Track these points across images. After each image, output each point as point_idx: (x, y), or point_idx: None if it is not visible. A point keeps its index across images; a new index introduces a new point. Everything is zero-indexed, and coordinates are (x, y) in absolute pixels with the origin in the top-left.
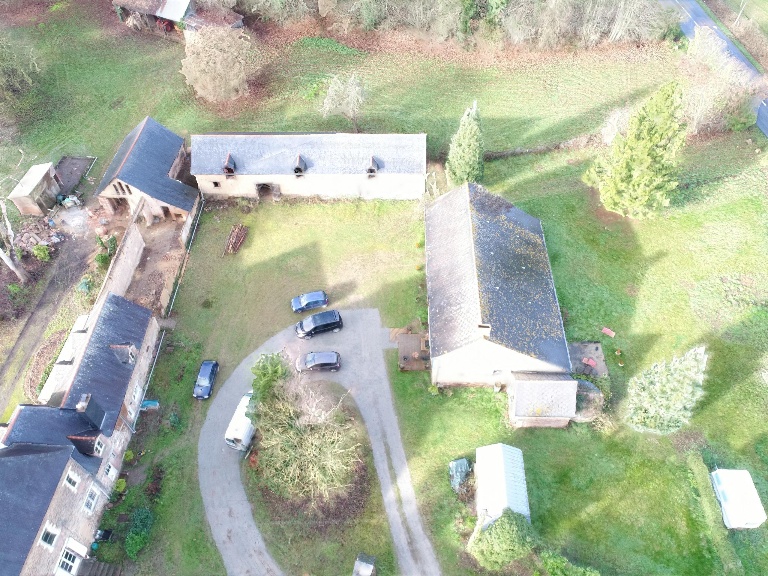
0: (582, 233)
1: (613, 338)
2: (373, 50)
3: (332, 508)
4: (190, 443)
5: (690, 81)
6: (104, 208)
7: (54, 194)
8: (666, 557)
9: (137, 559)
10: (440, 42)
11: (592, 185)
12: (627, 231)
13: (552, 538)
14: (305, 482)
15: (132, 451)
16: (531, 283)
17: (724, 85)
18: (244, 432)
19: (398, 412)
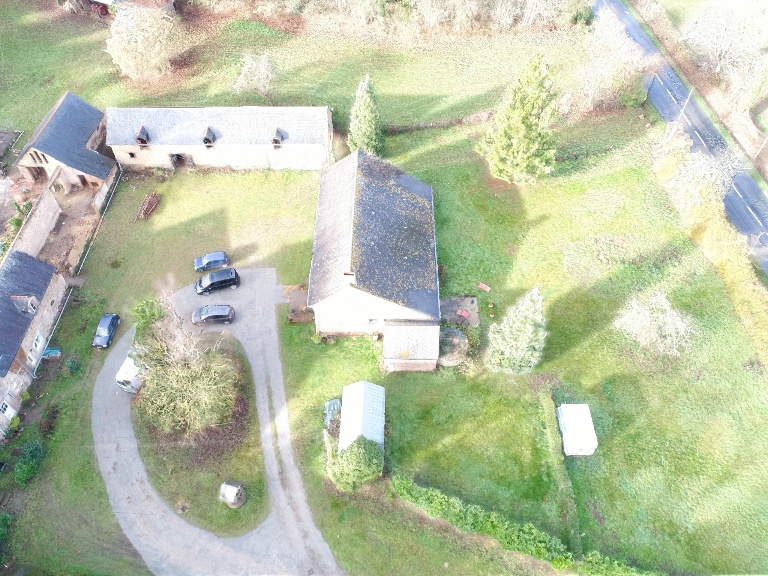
0: (473, 199)
1: (488, 292)
2: (298, 33)
3: (212, 443)
4: (86, 387)
5: (595, 62)
6: (25, 177)
7: None
8: (508, 481)
9: (26, 487)
10: (362, 25)
11: (484, 155)
12: (515, 197)
13: (408, 466)
14: (181, 415)
15: (31, 394)
16: (411, 241)
17: (620, 64)
18: (133, 375)
19: (283, 359)
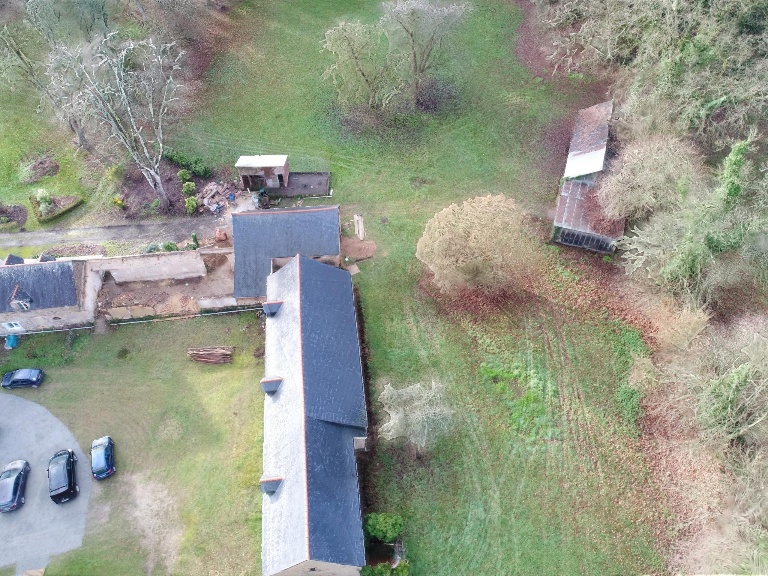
0: None
1: None
2: (650, 443)
3: None
4: None
5: None
6: None
7: (268, 185)
8: None
9: None
10: None
11: None
12: None
13: None
14: None
15: None
16: None
17: None
18: None
19: None
